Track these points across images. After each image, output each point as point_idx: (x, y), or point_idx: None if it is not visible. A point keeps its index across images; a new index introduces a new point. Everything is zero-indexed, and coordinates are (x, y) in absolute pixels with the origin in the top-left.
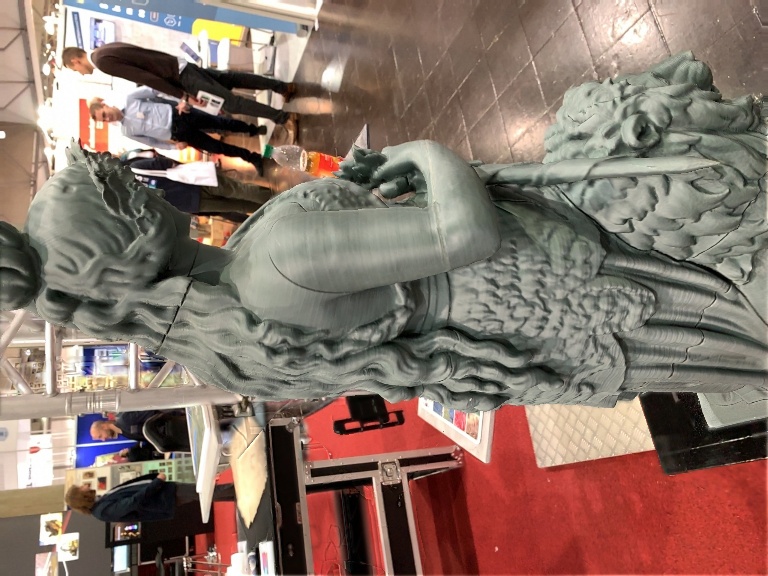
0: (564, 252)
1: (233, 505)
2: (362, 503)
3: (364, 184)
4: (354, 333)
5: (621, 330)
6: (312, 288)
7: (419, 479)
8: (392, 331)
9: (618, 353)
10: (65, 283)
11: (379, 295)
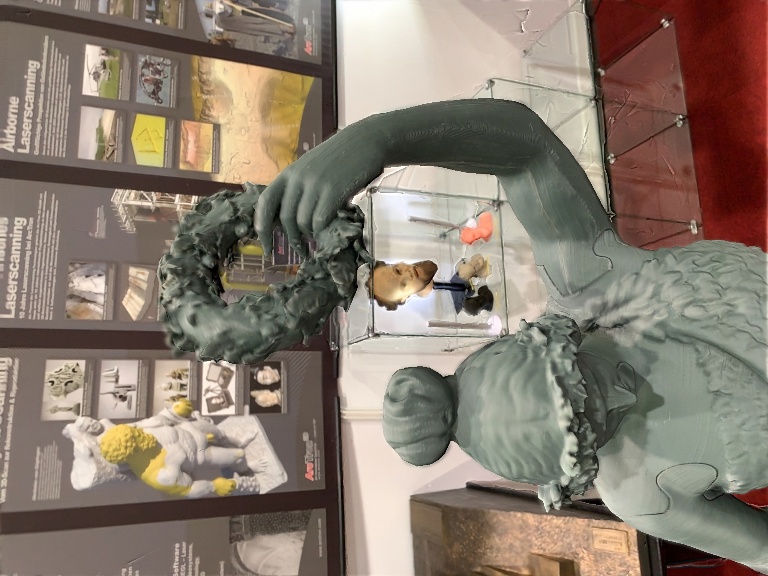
0: None
1: None
2: None
3: None
4: None
5: None
6: None
7: None
8: None
9: None
10: None
11: None
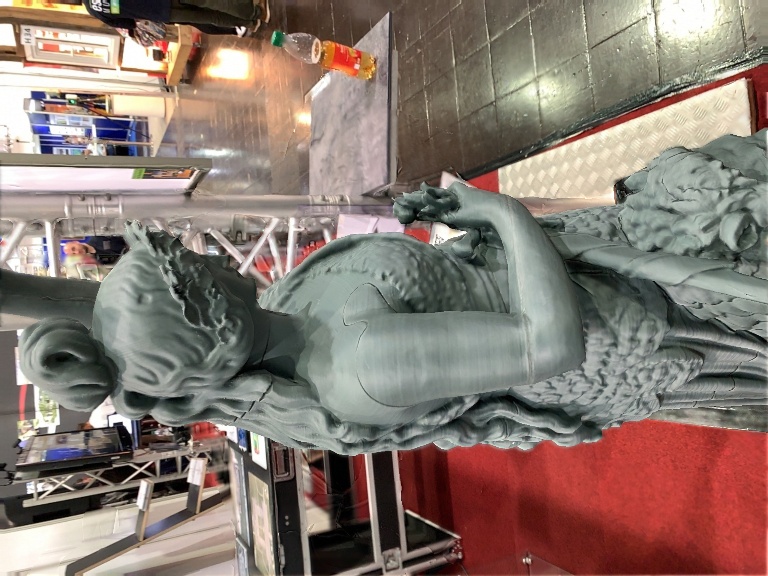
0: (632, 333)
1: None
2: None
3: (428, 217)
4: (424, 419)
5: (665, 391)
6: (397, 405)
7: None
8: (459, 413)
9: (656, 405)
10: (144, 389)
11: None
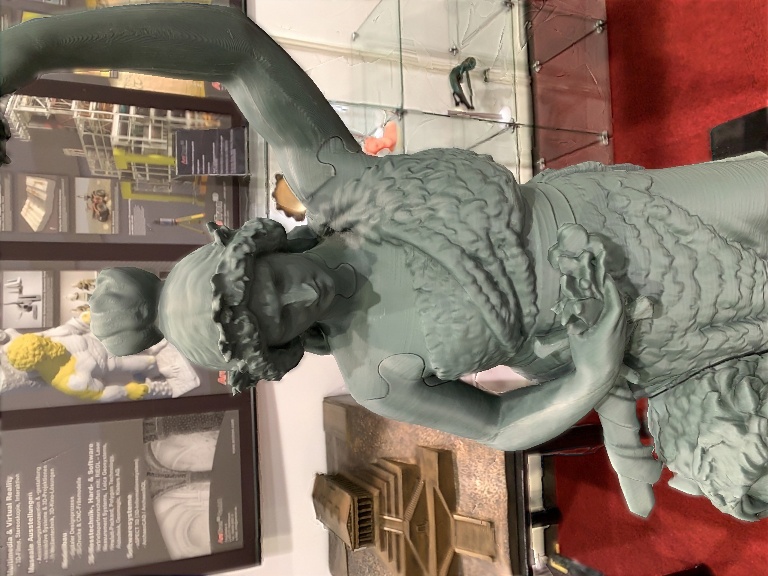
0: None
1: None
2: None
3: None
4: None
5: None
6: None
7: None
8: None
9: None
10: None
11: None
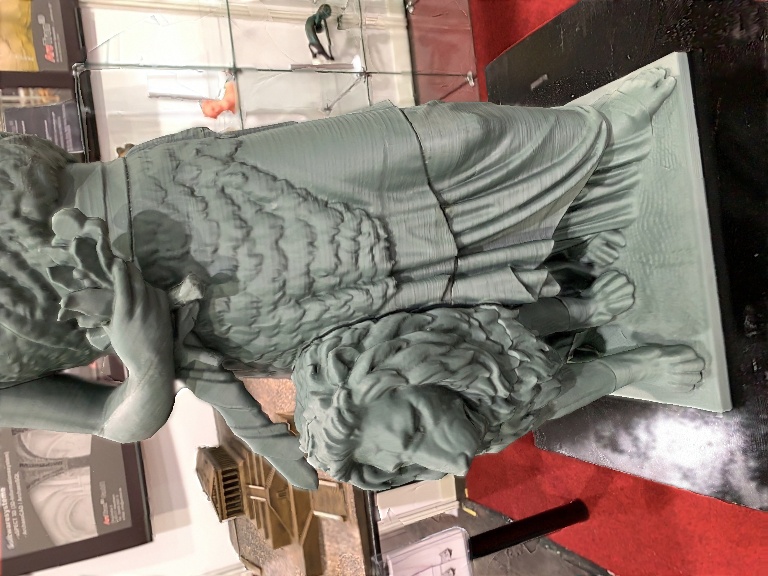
0: None
1: None
2: None
3: None
4: None
5: None
6: None
7: None
8: None
9: None
10: None
11: None
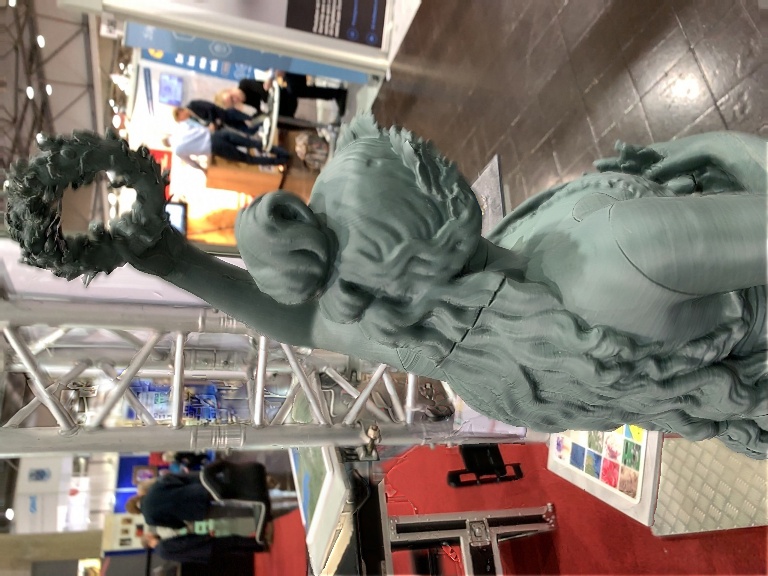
0: None
1: (305, 559)
2: (450, 565)
3: None
4: (686, 348)
5: None
6: (668, 286)
7: (500, 542)
8: (725, 349)
9: None
10: (364, 273)
11: (713, 303)
